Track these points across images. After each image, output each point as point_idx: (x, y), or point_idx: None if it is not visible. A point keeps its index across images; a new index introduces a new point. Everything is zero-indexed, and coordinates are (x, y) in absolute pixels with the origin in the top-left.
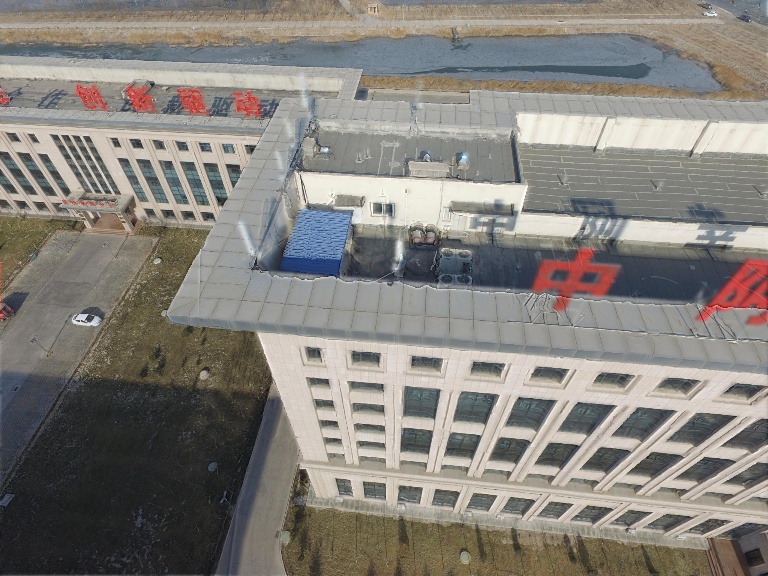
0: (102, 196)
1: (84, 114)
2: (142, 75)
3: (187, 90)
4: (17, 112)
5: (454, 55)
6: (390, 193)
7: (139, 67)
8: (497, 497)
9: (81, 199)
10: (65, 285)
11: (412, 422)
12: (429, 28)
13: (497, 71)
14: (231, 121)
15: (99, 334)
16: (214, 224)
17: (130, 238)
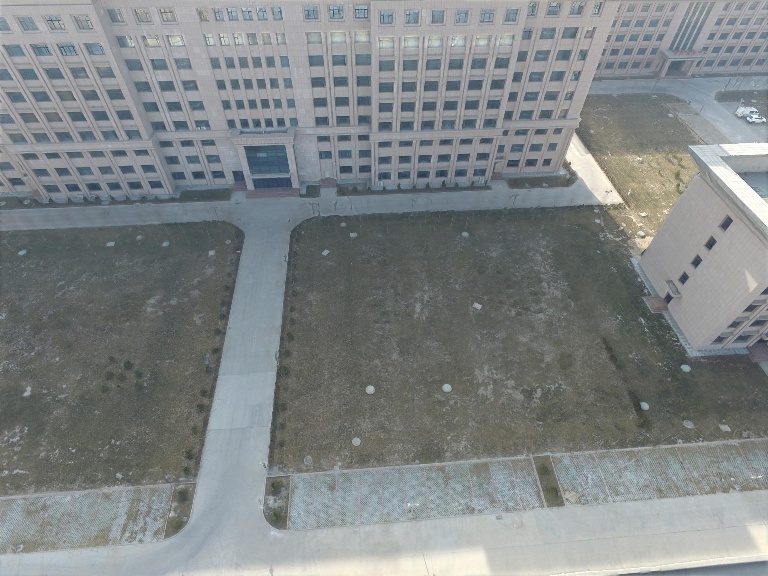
0: None
1: None
2: None
3: None
4: None
5: None
6: None
7: None
8: None
9: None
10: None
11: None
12: None
13: None
14: None
15: None
16: None
17: None
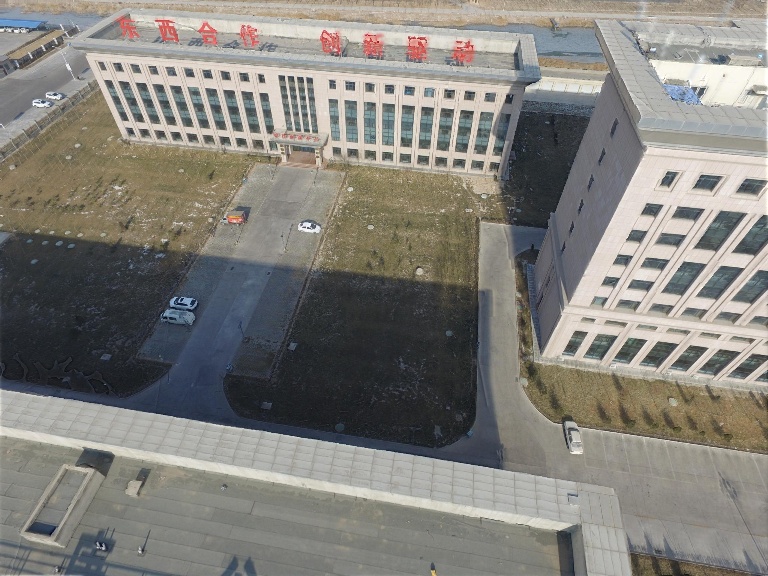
0: (300, 134)
1: (316, 57)
2: (340, 33)
3: (378, 47)
4: (260, 54)
5: (557, 41)
6: (710, 78)
7: (340, 26)
8: (707, 350)
9: (286, 135)
10: (279, 203)
11: (695, 254)
12: (529, 18)
13: (600, 56)
14: (443, 67)
15: (322, 239)
16: (623, 80)
17: (321, 171)
